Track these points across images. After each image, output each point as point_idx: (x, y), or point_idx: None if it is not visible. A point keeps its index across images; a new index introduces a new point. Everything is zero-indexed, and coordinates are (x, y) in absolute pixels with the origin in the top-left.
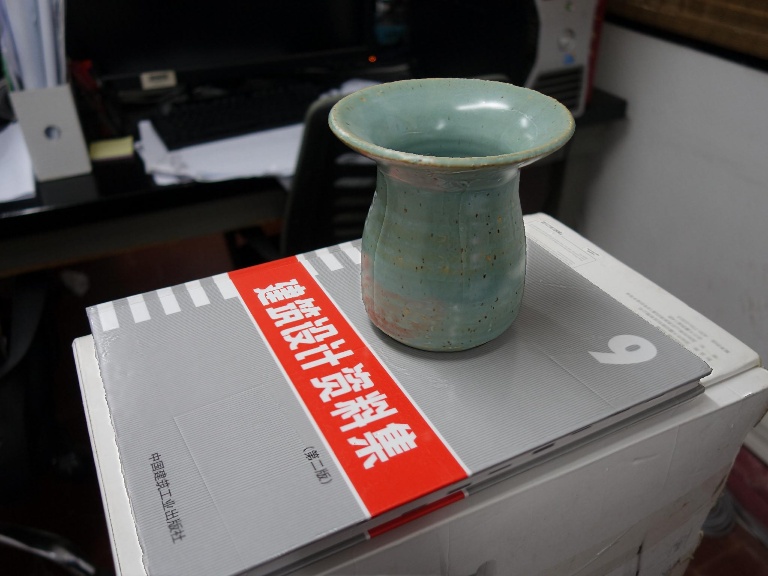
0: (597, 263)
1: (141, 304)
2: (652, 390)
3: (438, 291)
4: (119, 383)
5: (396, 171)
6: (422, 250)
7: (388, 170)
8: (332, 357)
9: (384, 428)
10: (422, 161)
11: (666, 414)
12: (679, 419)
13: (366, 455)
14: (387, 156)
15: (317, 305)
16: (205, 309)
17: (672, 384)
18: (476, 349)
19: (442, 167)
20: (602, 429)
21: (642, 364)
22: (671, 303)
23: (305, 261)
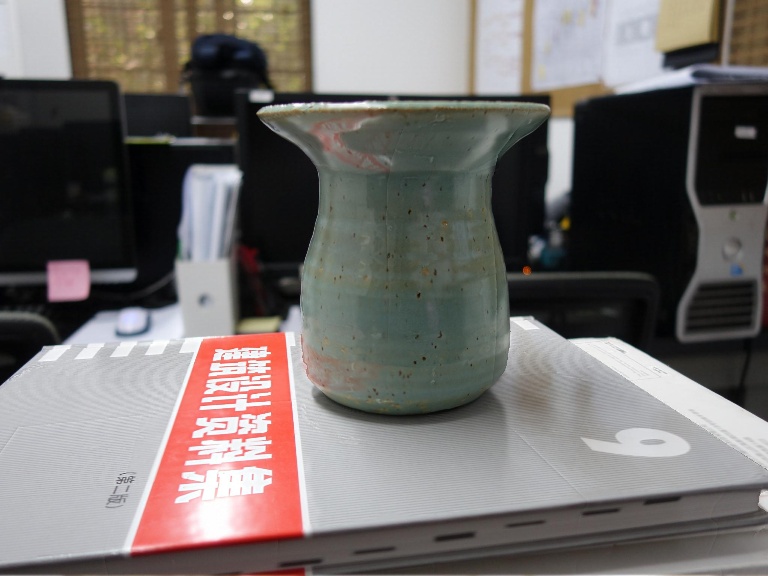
0: (660, 380)
1: (96, 348)
2: (658, 486)
3: (358, 310)
4: (2, 396)
5: (311, 148)
6: (342, 255)
7: (309, 154)
8: (242, 404)
9: (238, 469)
10: (312, 107)
11: (698, 546)
12: (723, 561)
13: (189, 490)
14: (282, 110)
15: (269, 365)
16: (151, 357)
17: (696, 484)
18: (424, 417)
19: (334, 113)
20: (569, 536)
21: (657, 458)
22: (754, 425)
23: (291, 336)
